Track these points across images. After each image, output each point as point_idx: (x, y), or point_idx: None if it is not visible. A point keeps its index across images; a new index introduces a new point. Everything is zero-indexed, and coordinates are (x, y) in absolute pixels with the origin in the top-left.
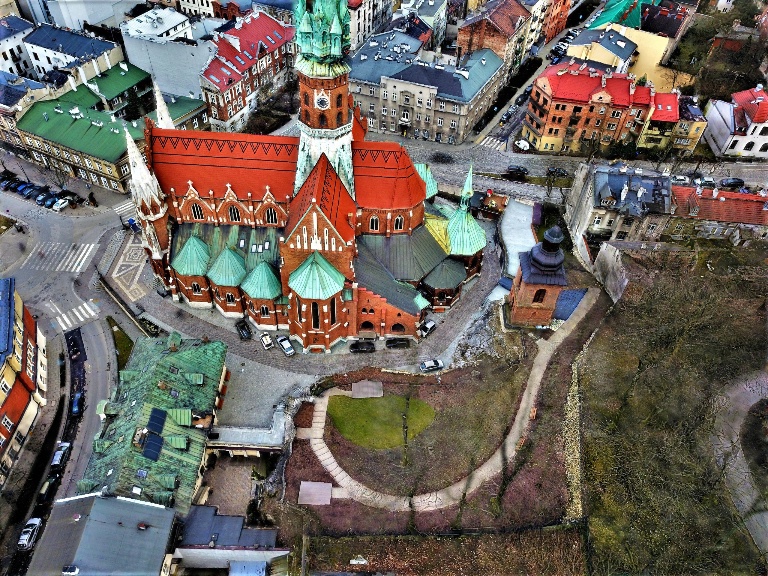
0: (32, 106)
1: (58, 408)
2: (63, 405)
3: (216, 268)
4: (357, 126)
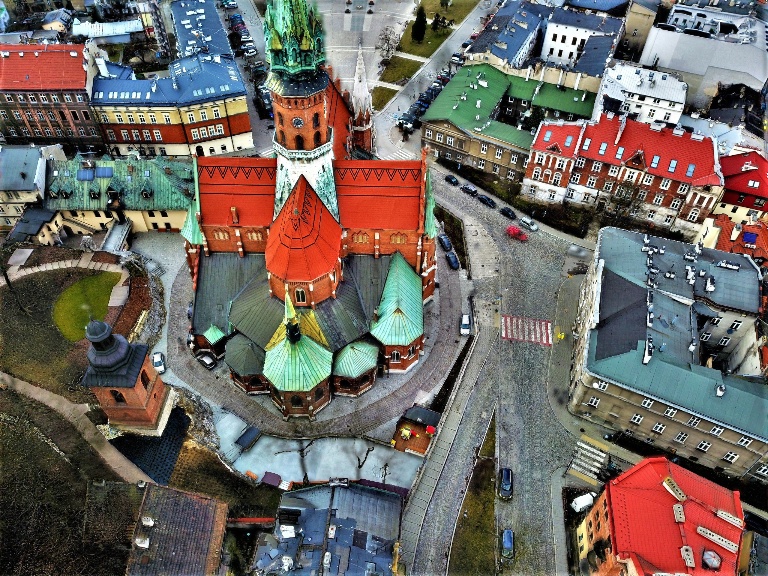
0: (483, 64)
1: None
2: None
3: None
4: (409, 214)
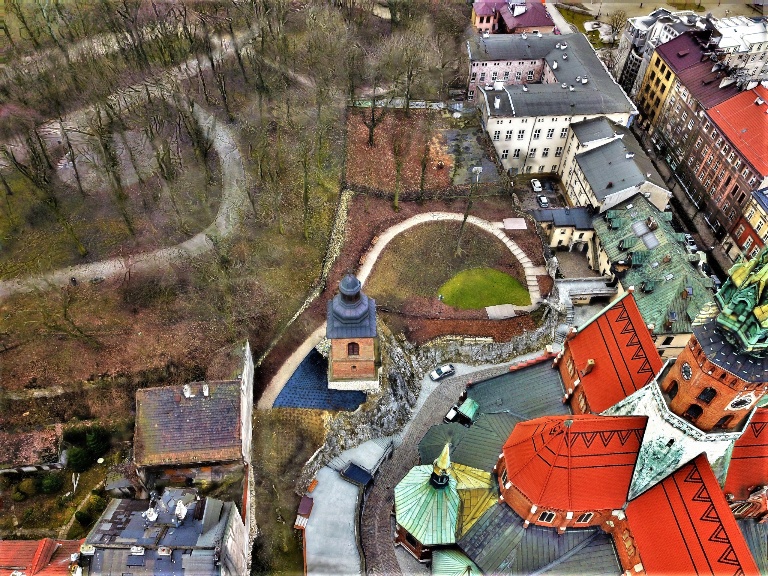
0: None
1: None
2: None
3: None
4: None
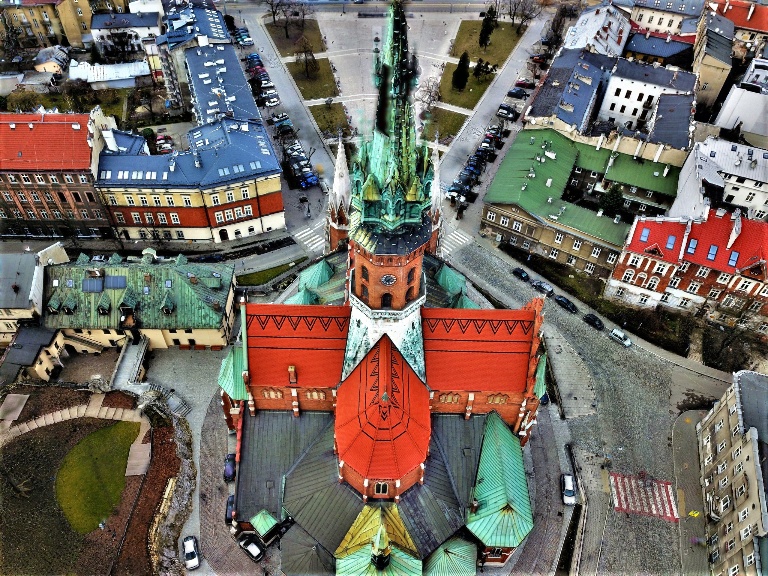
0: (546, 129)
1: (211, 250)
2: (213, 252)
3: None
4: (514, 373)
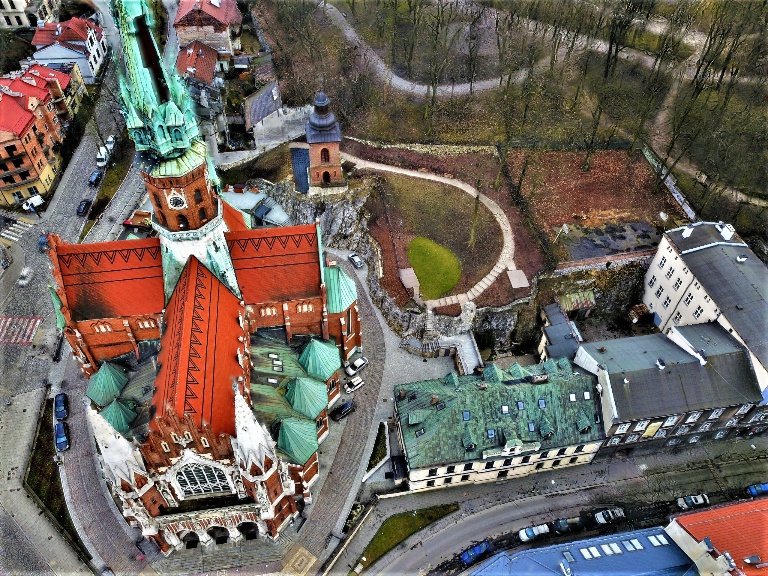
0: None
1: None
2: None
3: (310, 403)
4: None
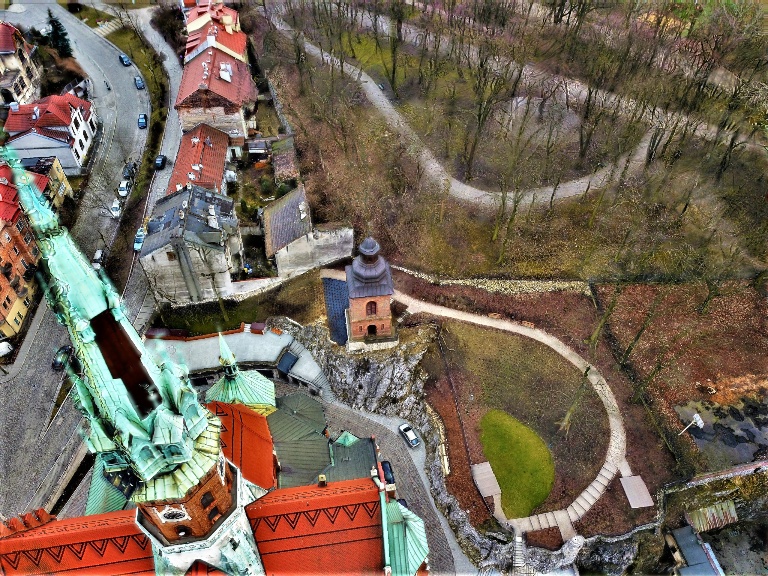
0: None
1: None
2: None
3: None
4: None
